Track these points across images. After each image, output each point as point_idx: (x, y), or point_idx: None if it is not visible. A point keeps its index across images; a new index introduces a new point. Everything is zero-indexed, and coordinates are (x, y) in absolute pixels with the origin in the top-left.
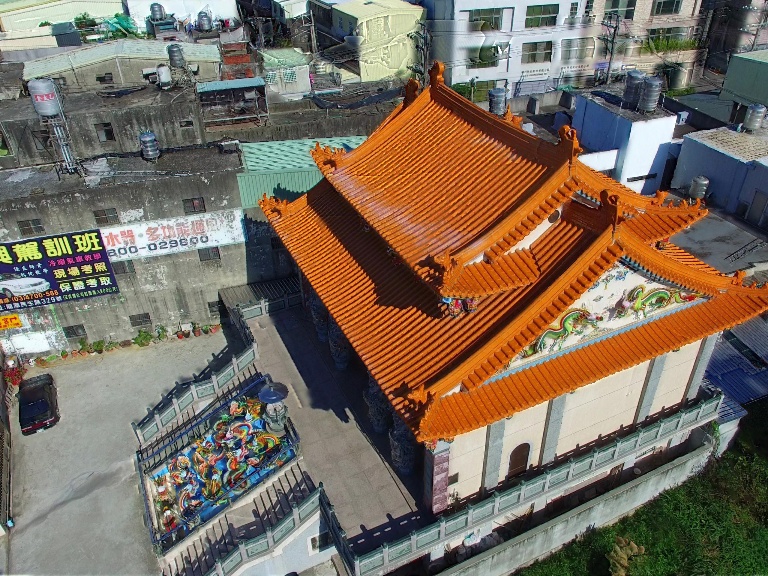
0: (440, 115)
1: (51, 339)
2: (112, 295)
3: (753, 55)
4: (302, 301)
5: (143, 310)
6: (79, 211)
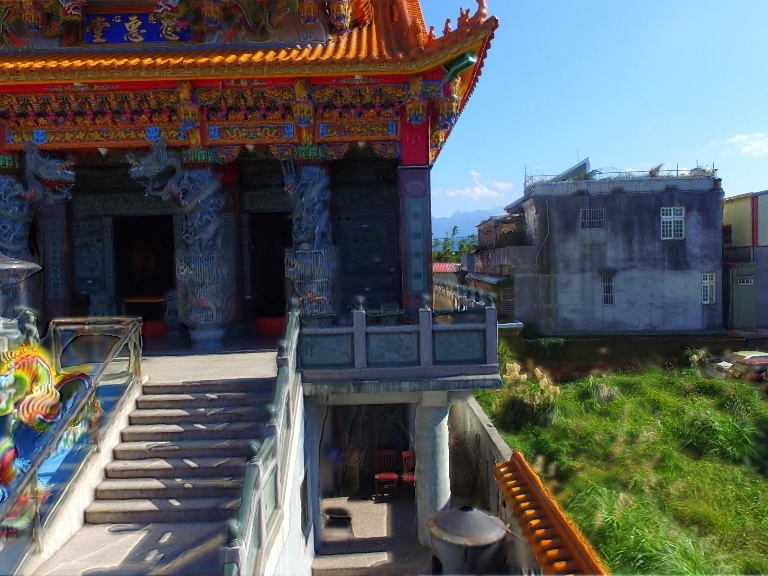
0: None
1: None
2: None
3: None
4: None
5: None
6: None
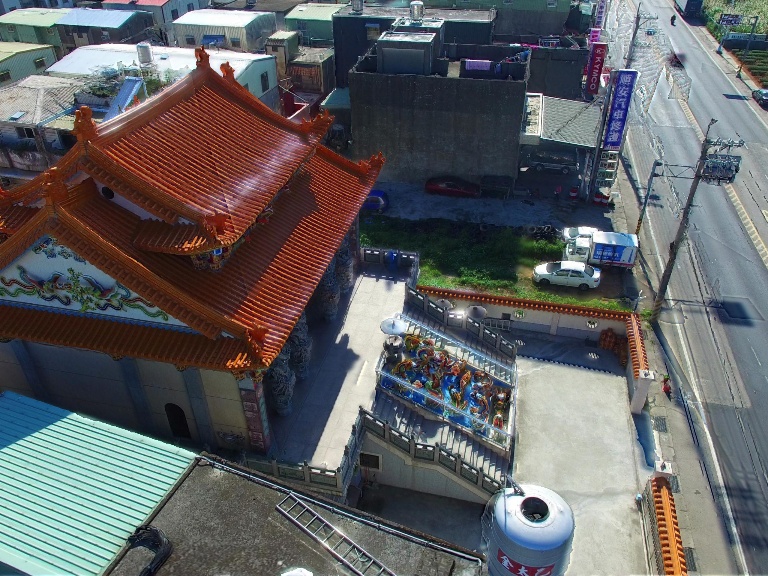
0: None
1: None
2: None
3: None
4: None
5: None
6: None
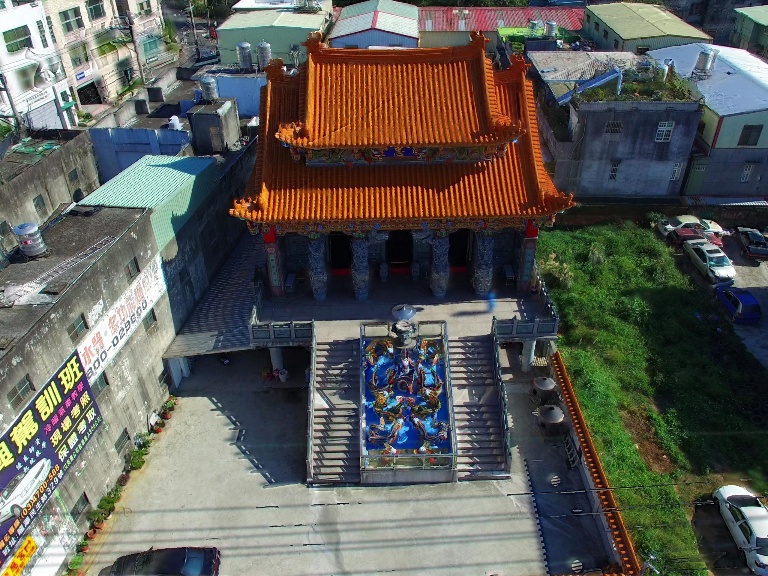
0: (339, 70)
1: (64, 540)
2: (98, 430)
3: (228, 26)
4: (275, 290)
5: (122, 428)
6: (57, 337)
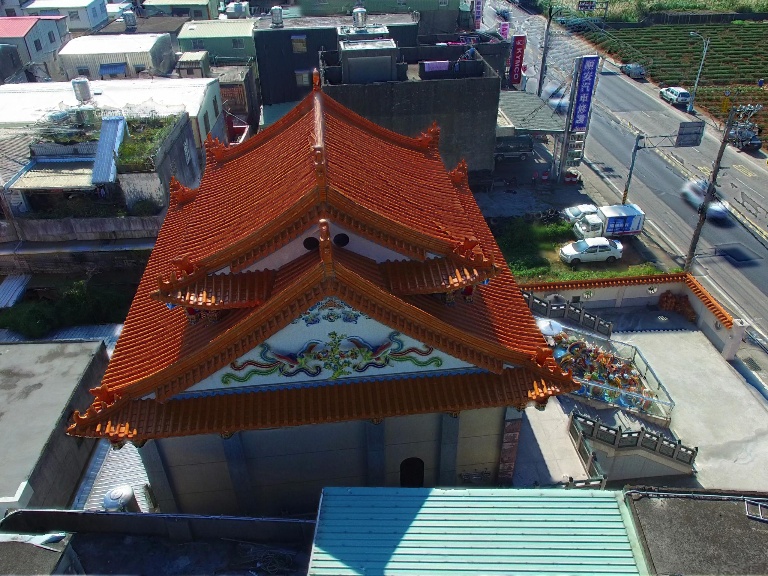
0: None
1: None
2: None
3: None
4: None
5: None
6: None
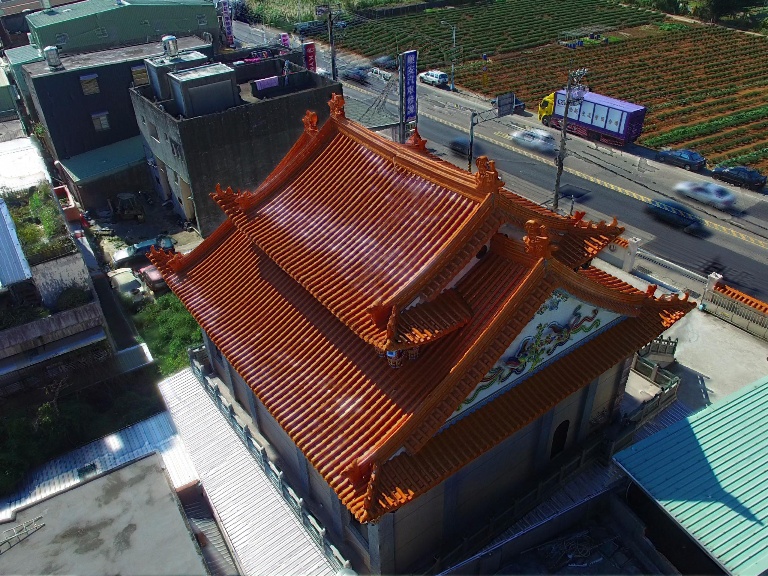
0: None
1: None
2: None
3: None
4: None
5: None
6: None
